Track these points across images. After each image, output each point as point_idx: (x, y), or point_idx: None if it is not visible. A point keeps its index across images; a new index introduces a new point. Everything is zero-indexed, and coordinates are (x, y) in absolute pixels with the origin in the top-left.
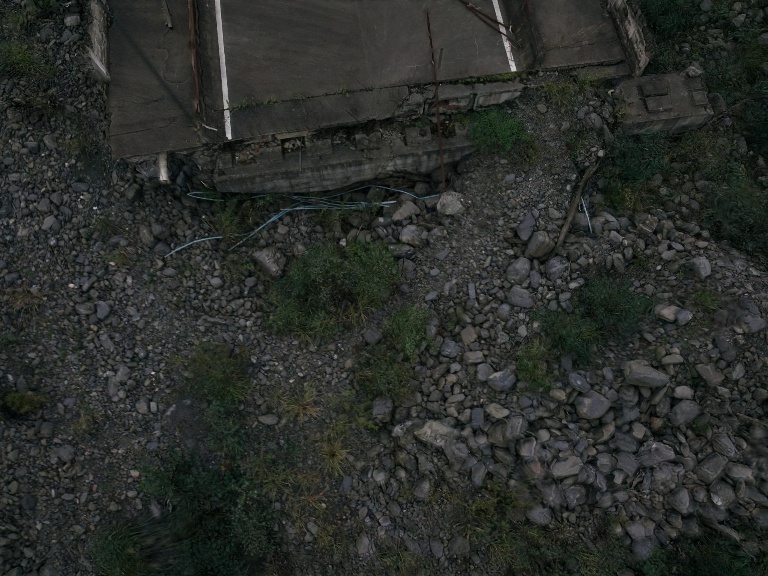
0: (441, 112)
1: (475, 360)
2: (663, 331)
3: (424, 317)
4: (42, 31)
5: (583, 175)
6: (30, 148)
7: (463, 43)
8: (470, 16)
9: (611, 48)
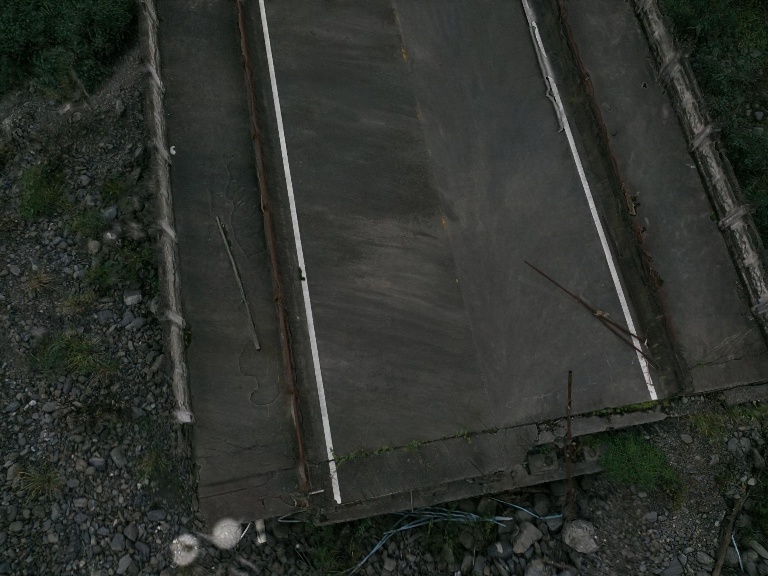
0: None
1: None
2: None
3: None
4: (100, 314)
5: (732, 508)
6: (96, 466)
7: (593, 362)
8: (598, 325)
9: (761, 363)
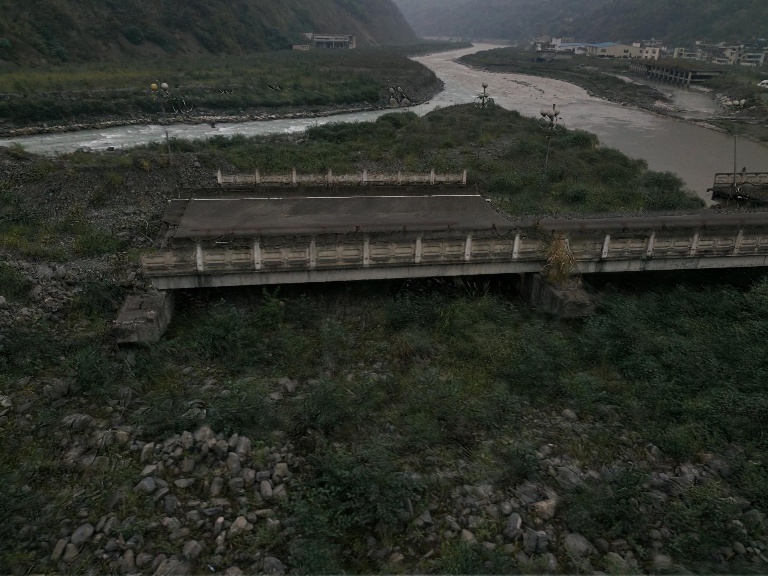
0: None
1: None
2: None
3: None
4: None
5: None
6: None
7: (199, 235)
8: None
9: None
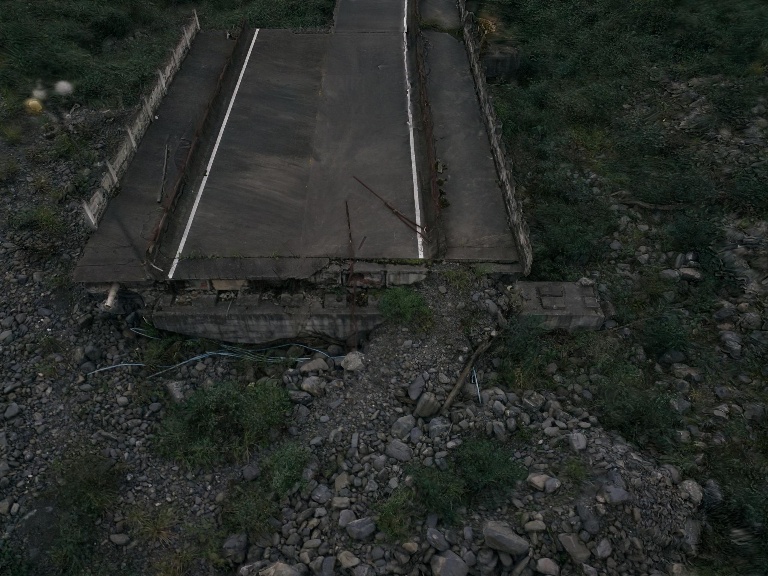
0: (359, 285)
1: (339, 504)
2: (531, 498)
3: (305, 460)
4: (71, 203)
5: (476, 350)
6: (20, 279)
7: (384, 235)
8: (395, 218)
9: (508, 252)
